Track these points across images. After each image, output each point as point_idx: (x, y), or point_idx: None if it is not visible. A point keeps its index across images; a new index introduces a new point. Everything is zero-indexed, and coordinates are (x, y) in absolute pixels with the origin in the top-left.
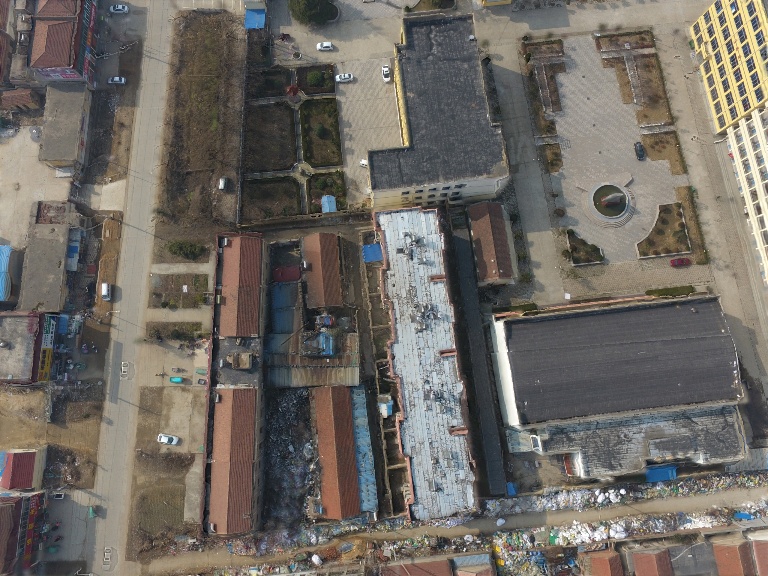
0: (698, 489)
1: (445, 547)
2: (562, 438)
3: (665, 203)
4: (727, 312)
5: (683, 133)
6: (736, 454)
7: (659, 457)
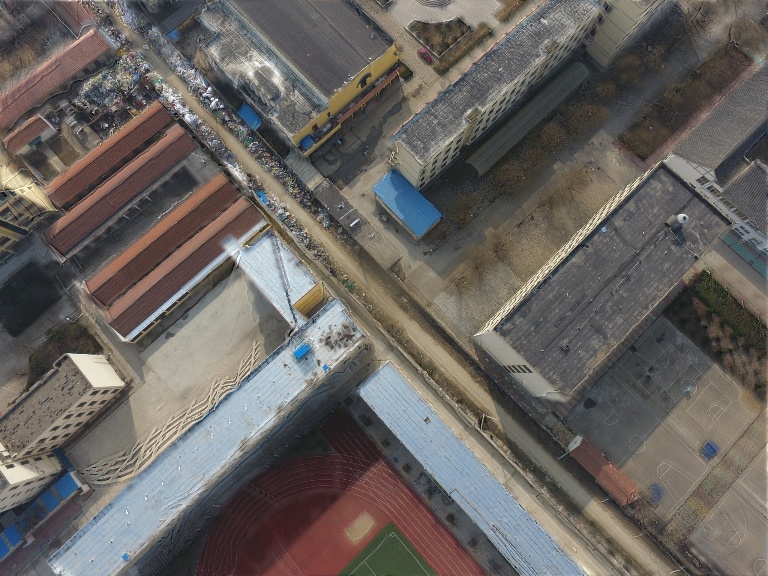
0: (260, 154)
1: (107, 29)
2: (219, 19)
3: (463, 20)
4: (412, 108)
5: (532, 3)
6: (292, 132)
7: (249, 79)
